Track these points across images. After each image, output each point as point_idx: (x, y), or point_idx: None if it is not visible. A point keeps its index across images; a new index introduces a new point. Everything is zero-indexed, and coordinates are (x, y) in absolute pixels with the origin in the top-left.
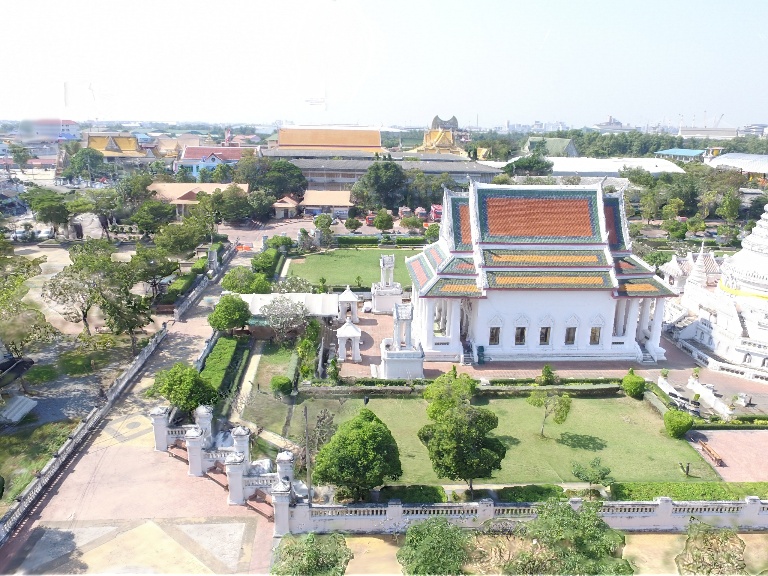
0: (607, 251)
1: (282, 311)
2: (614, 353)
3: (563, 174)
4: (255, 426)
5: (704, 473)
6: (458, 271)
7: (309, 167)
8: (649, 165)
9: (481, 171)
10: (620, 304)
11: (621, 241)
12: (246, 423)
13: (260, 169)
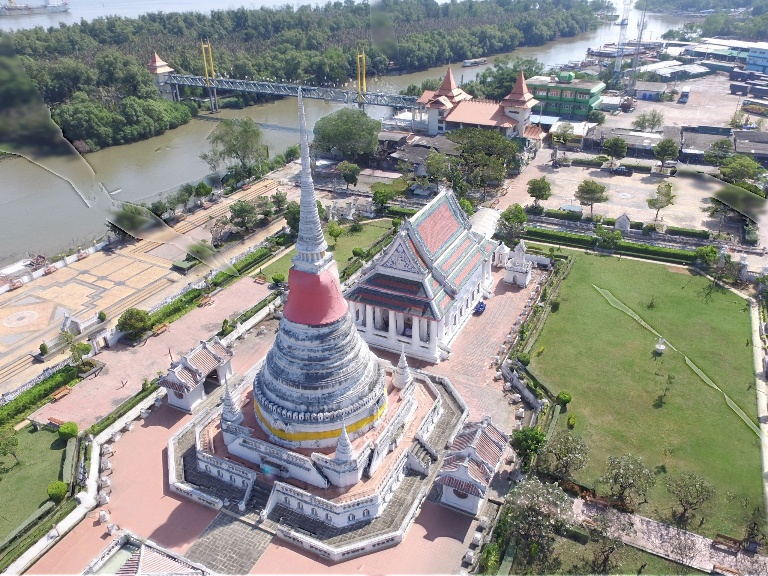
0: None
1: None
2: None
3: None
4: (377, 220)
5: None
6: None
7: None
8: None
9: None
10: None
11: None
12: None
13: None
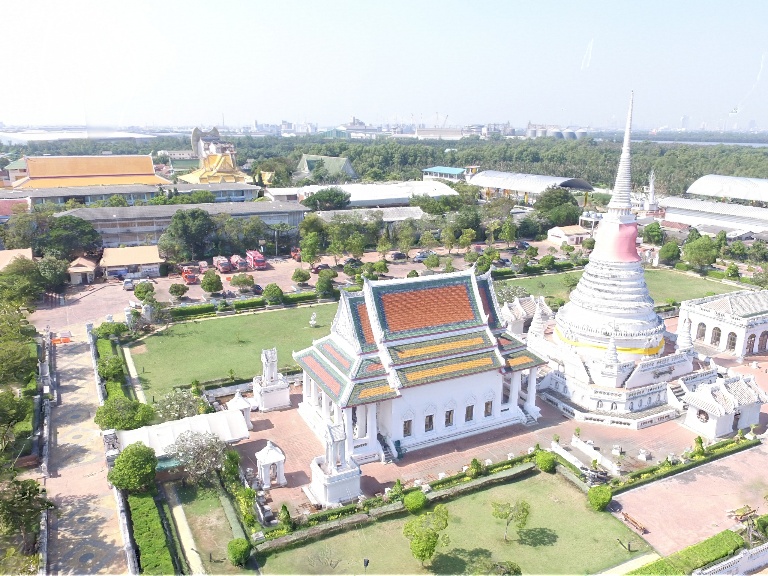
0: (489, 331)
1: (199, 452)
2: (504, 420)
3: (358, 203)
4: None
5: (638, 545)
6: (370, 374)
7: (98, 218)
8: (429, 189)
9: (289, 210)
10: None
11: (496, 319)
12: None
13: (39, 227)
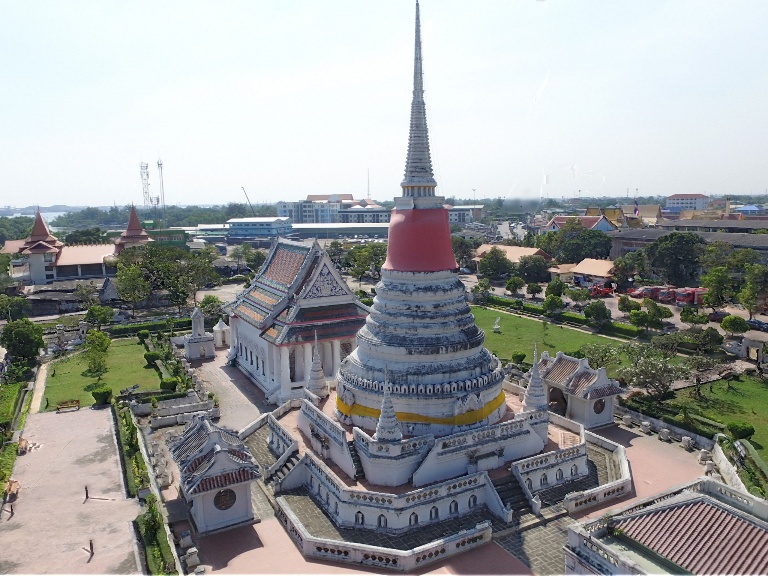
0: None
1: None
2: None
3: None
4: None
5: None
6: None
7: (631, 237)
8: None
9: None
10: None
11: None
12: (111, 341)
13: (575, 237)
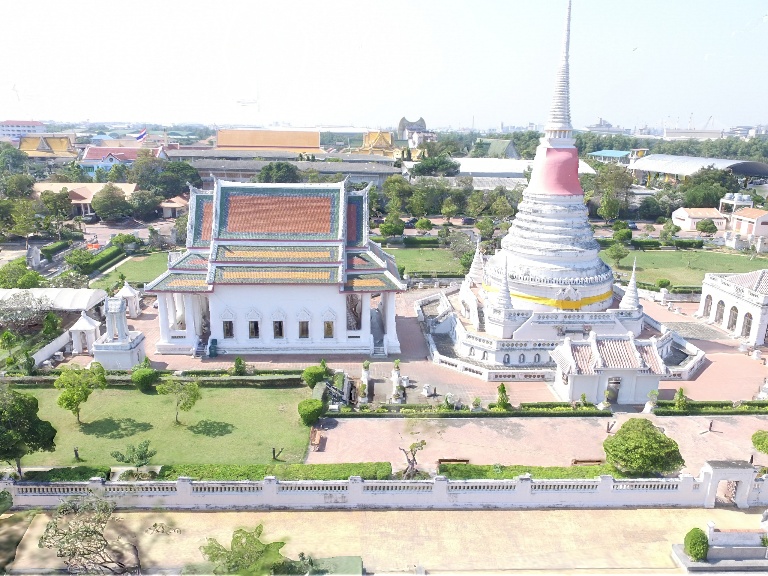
0: (341, 247)
1: (14, 305)
2: (348, 346)
3: (473, 175)
4: None
5: (295, 457)
6: (190, 266)
7: (209, 167)
8: None
9: (378, 171)
10: None
11: (360, 238)
12: None
13: (155, 169)
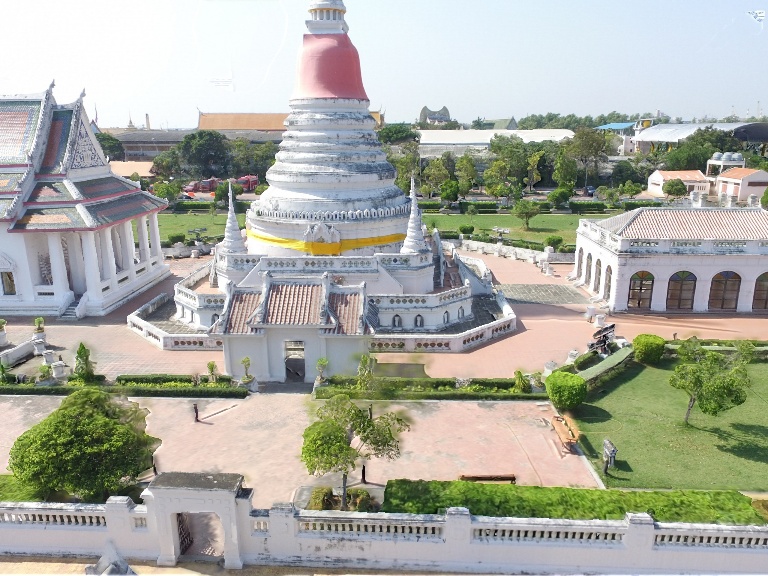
0: (24, 174)
1: None
2: (35, 306)
3: None
4: None
5: None
6: None
7: (137, 140)
8: (543, 135)
9: None
10: (67, 245)
11: (59, 163)
12: None
13: None
